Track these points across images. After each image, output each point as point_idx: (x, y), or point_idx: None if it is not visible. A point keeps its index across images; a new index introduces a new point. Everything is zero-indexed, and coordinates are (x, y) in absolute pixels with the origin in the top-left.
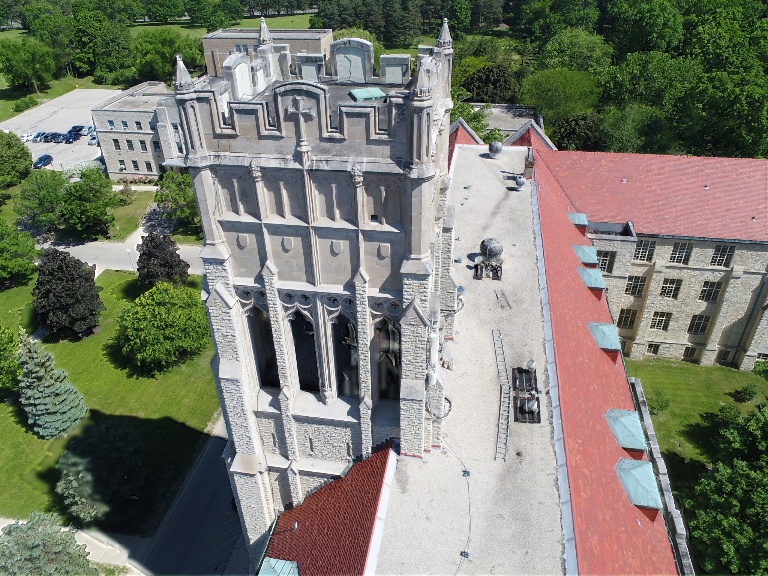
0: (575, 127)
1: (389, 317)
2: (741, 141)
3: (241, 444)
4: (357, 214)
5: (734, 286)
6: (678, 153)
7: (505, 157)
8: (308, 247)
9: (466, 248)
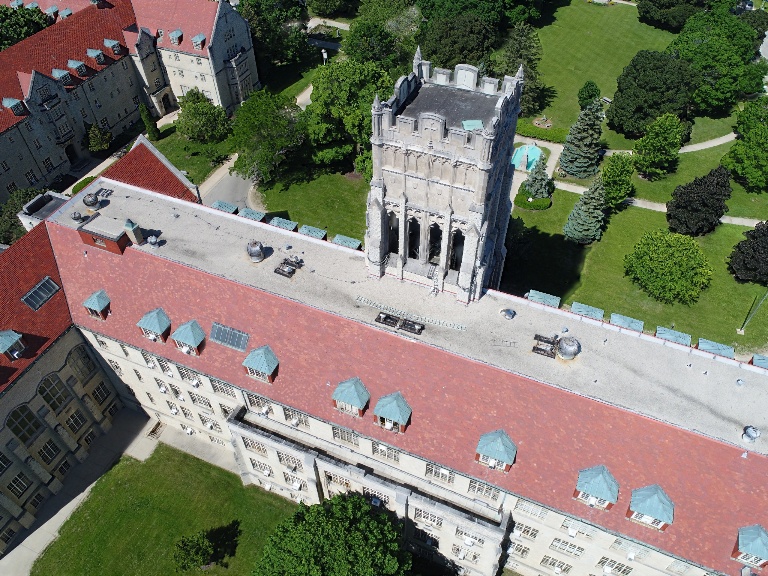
0: None
1: None
2: None
3: None
4: None
5: None
6: None
7: None
8: None
9: (590, 343)
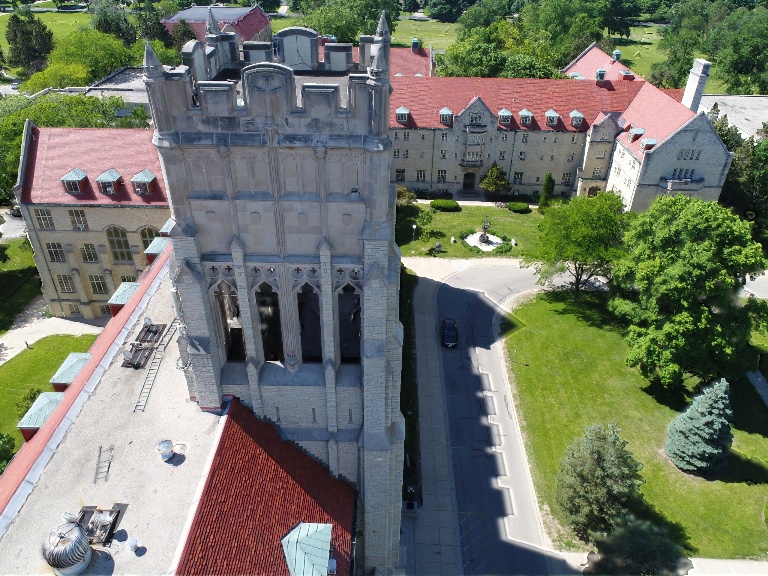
0: None
1: None
2: None
3: None
4: None
5: None
6: None
7: None
8: None
9: None
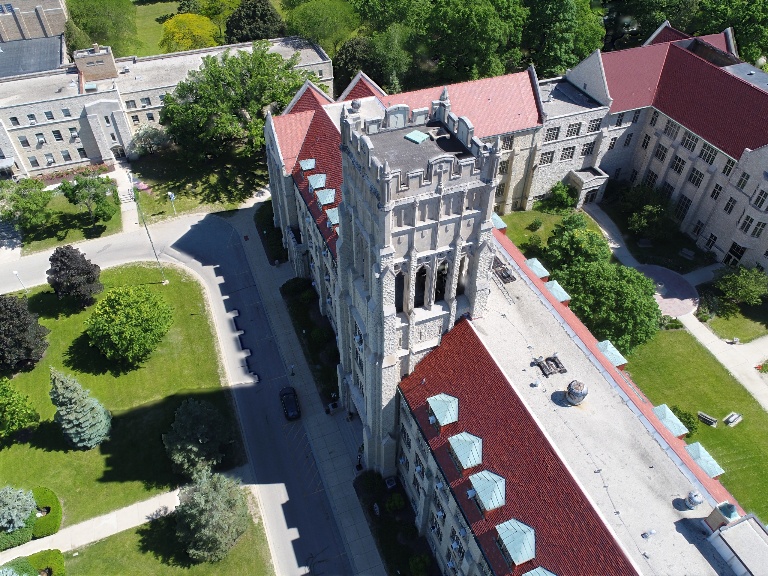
0: (354, 53)
1: (468, 253)
2: (479, 49)
3: (388, 351)
4: (462, 209)
5: (516, 160)
6: (434, 61)
7: (364, 109)
8: (434, 232)
9: None
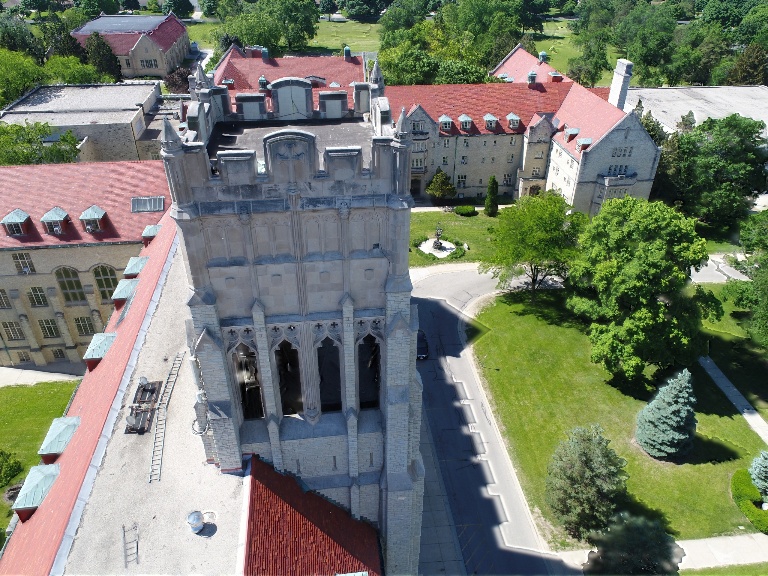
0: None
1: None
2: None
3: None
4: None
5: None
6: None
7: None
8: None
9: None
